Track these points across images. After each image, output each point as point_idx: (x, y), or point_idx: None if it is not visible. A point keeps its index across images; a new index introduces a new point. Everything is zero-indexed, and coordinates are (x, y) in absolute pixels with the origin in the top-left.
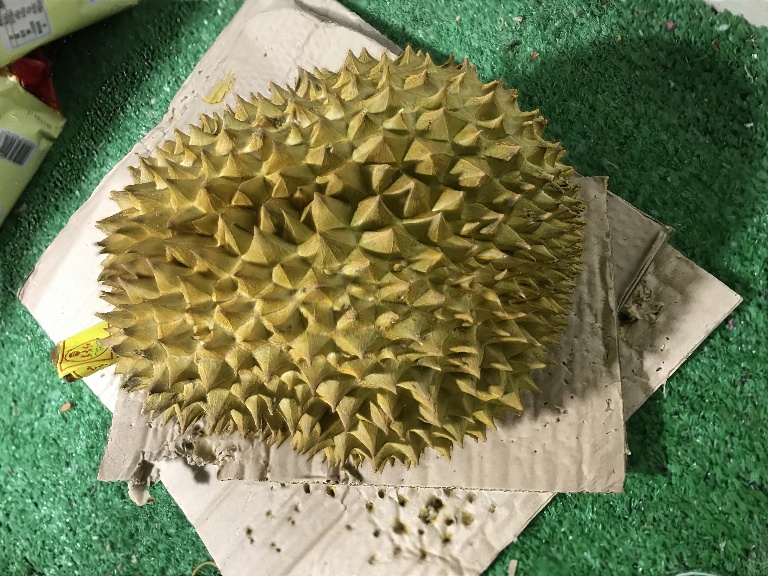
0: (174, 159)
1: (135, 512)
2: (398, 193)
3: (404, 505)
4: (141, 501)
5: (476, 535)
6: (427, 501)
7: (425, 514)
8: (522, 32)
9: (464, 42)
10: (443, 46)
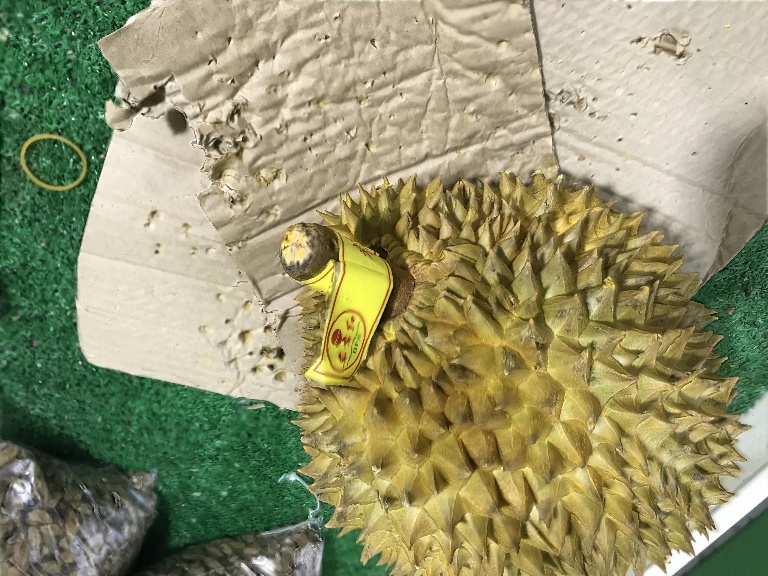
0: (631, 430)
1: (62, 6)
2: (585, 569)
3: (266, 331)
4: (114, 122)
5: (271, 388)
6: (279, 347)
7: (267, 348)
8: (759, 295)
9: (763, 243)
10: (764, 224)
